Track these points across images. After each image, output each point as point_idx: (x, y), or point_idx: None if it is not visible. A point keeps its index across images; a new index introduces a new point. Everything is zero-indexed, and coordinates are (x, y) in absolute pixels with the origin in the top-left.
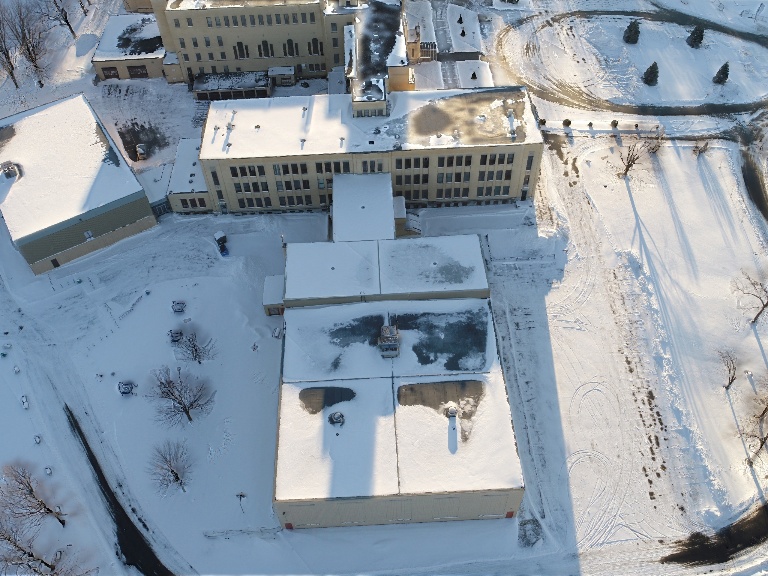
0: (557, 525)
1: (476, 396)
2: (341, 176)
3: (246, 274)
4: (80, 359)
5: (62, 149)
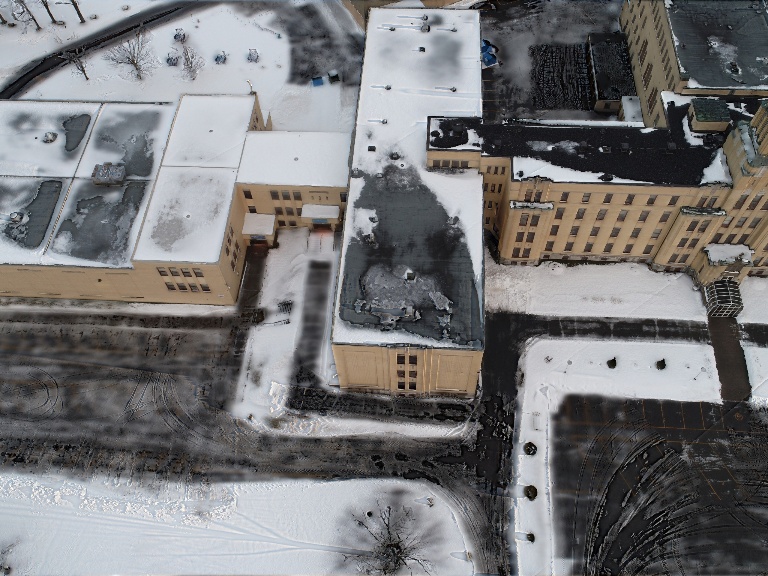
0: None
1: (25, 240)
2: None
3: (283, 99)
4: (220, 7)
5: None
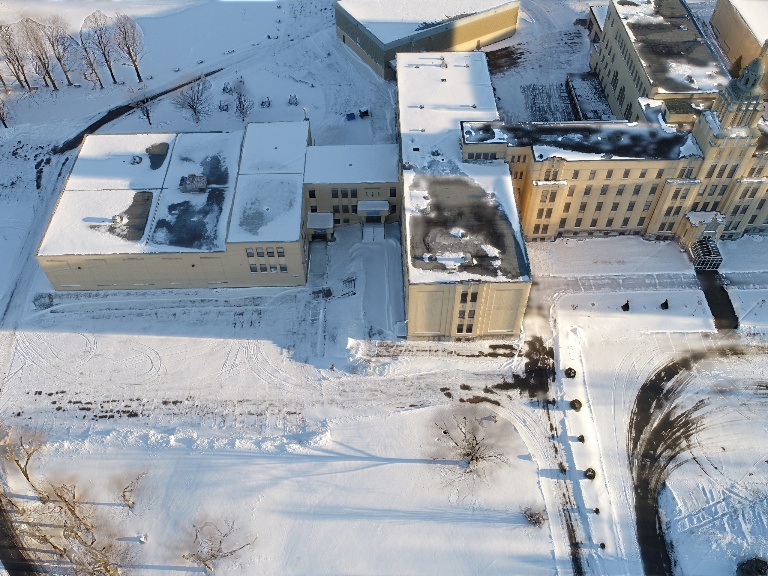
0: (43, 320)
1: (128, 236)
2: (396, 149)
3: (323, 131)
4: None
5: (440, 3)
